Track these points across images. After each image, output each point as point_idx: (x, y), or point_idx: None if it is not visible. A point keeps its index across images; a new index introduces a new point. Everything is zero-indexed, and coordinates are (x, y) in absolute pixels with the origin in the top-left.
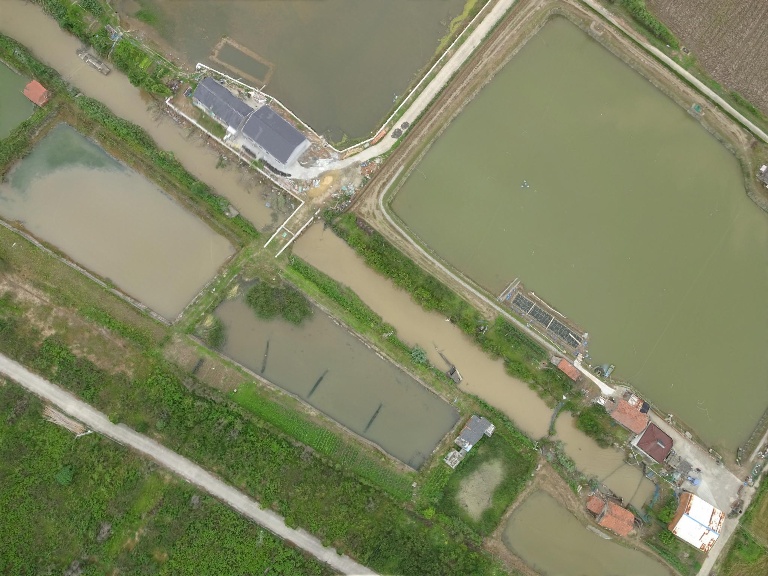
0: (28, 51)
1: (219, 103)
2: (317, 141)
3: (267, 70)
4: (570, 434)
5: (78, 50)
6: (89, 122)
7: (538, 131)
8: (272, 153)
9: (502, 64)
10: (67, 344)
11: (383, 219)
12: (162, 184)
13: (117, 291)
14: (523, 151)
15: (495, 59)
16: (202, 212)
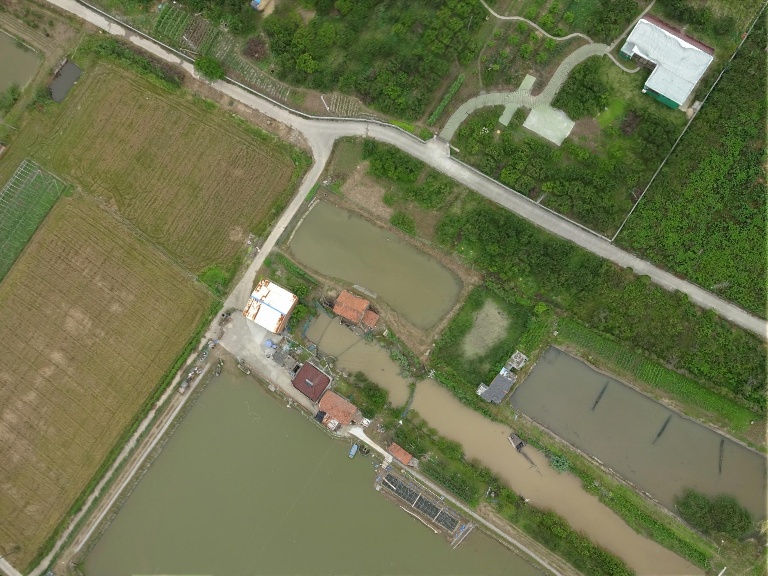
0: None
1: None
2: None
3: None
4: (394, 385)
5: None
6: None
7: None
8: None
9: None
10: None
11: None
12: None
13: None
14: None
15: None
16: None
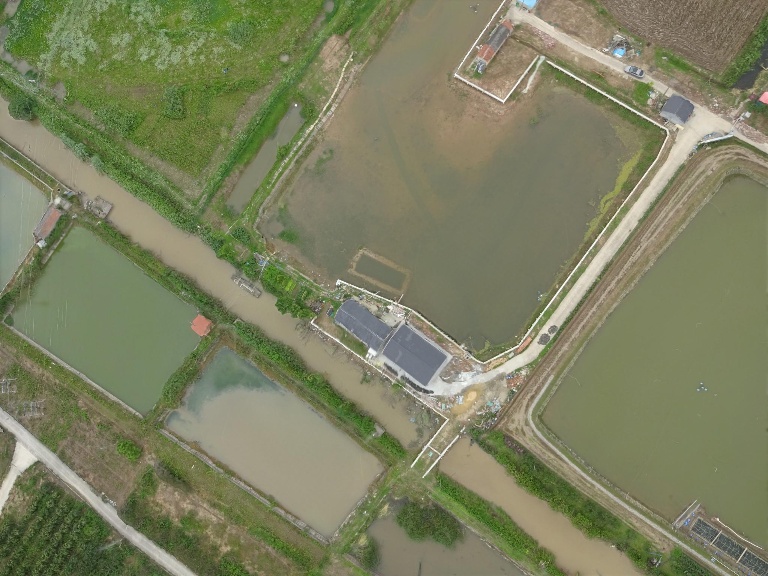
0: (193, 283)
1: (359, 327)
2: (458, 353)
3: (404, 278)
4: None
5: (233, 275)
6: (246, 348)
7: (716, 321)
8: (413, 375)
9: (666, 245)
10: (240, 561)
11: (533, 436)
12: (312, 404)
13: (279, 509)
14: (697, 347)
15: (657, 241)
16: (350, 431)
